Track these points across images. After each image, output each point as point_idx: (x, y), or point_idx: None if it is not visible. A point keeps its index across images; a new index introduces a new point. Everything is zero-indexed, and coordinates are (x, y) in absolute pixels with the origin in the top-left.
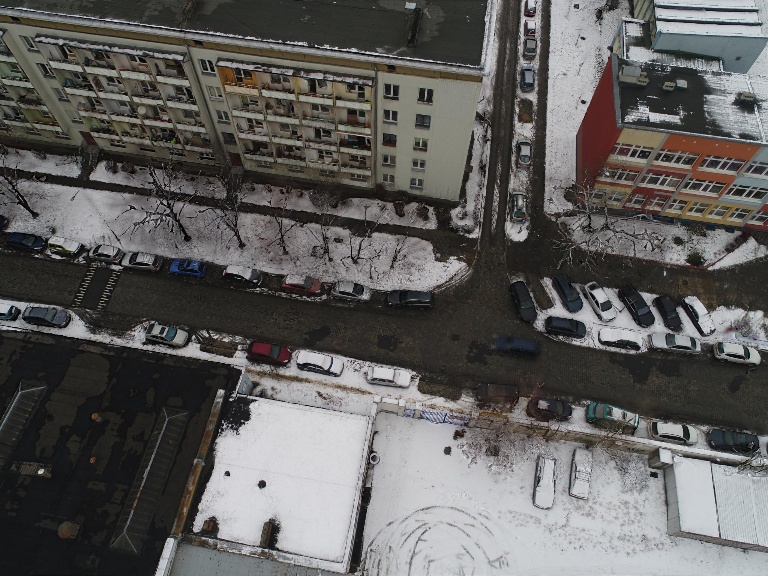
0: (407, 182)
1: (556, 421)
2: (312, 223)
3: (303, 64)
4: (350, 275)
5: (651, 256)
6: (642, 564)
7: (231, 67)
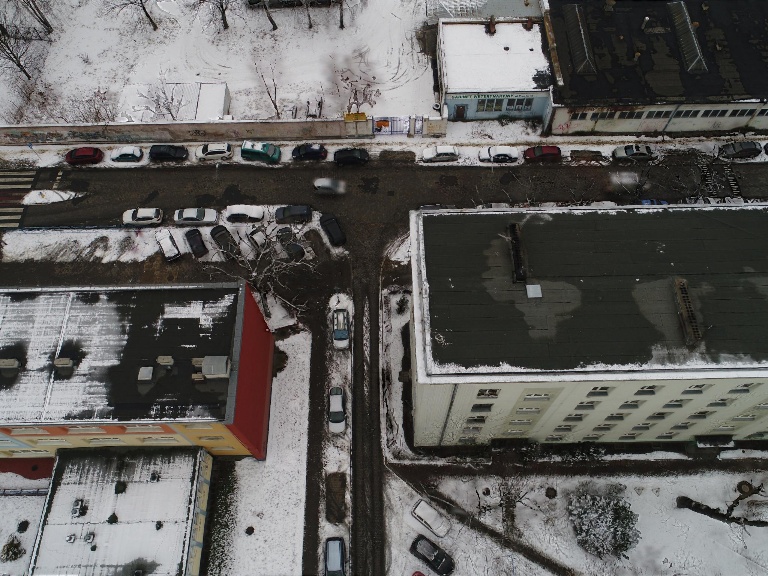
0: None
1: None
2: None
3: None
4: None
5: None
6: (251, 83)
7: None
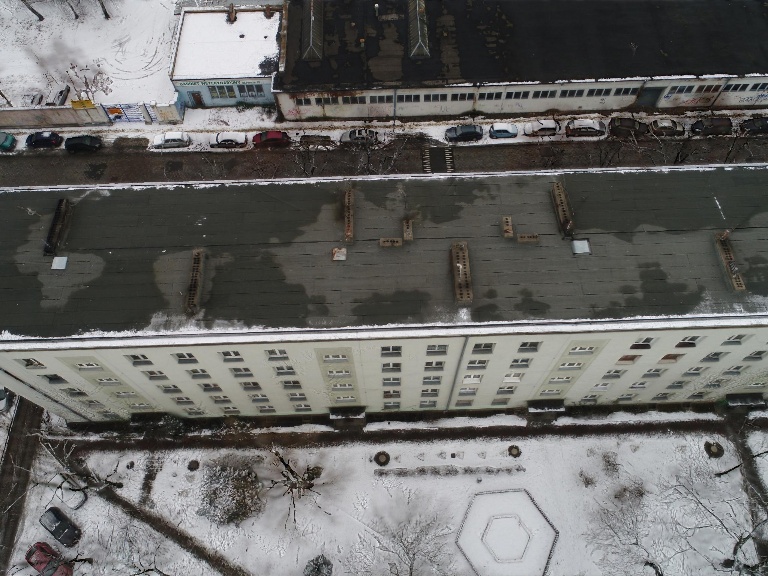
0: None
1: None
2: None
3: None
4: None
5: None
6: (5, 73)
7: None
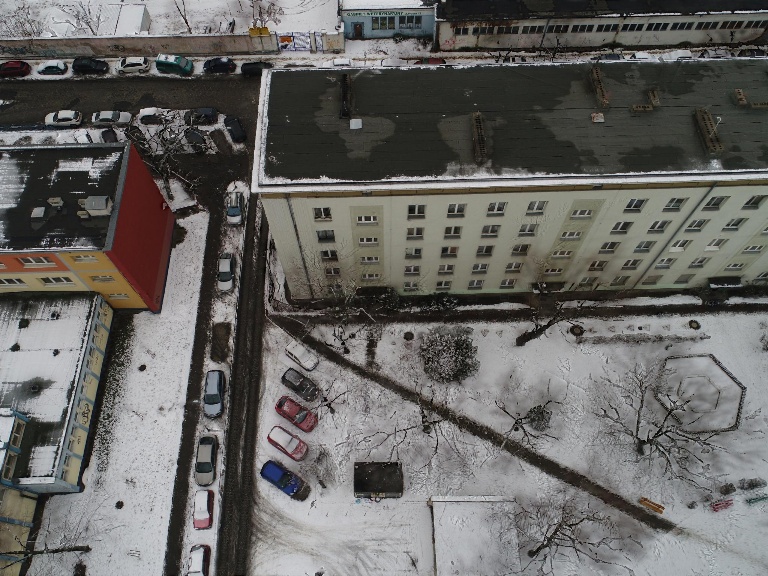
0: None
1: None
2: None
3: None
4: None
5: None
6: (171, 8)
7: None
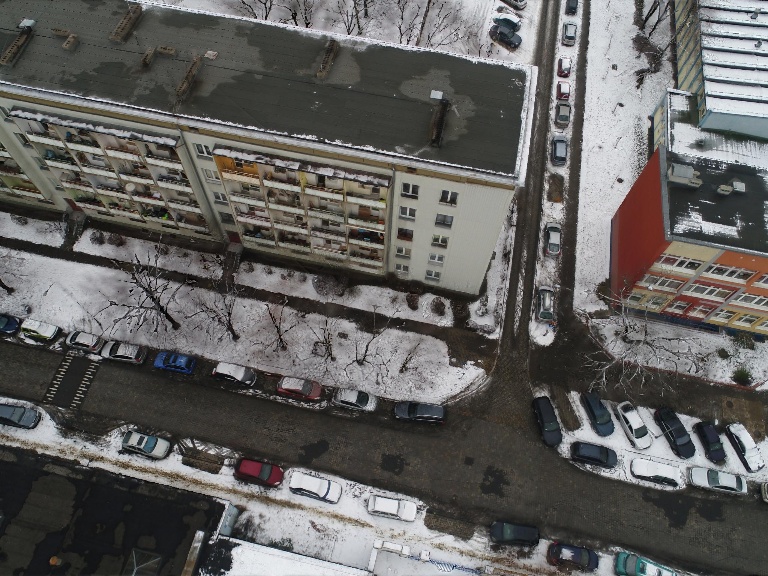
0: (422, 273)
1: (580, 572)
2: (315, 313)
3: (311, 157)
4: (354, 379)
5: (692, 371)
6: None
7: (229, 156)
